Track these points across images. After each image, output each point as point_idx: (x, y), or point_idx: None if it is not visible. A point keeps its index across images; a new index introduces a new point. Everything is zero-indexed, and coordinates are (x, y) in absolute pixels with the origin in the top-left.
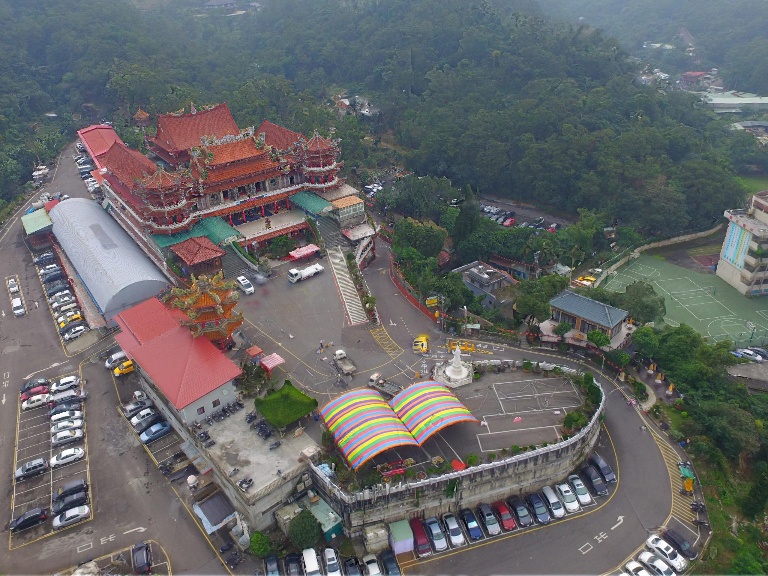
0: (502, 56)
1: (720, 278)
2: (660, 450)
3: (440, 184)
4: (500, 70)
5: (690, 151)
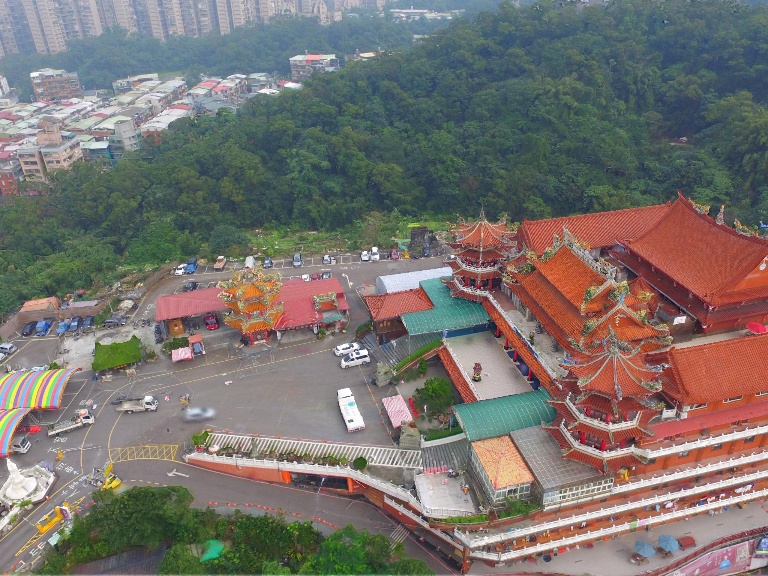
0: None
1: None
2: None
3: None
4: None
5: None
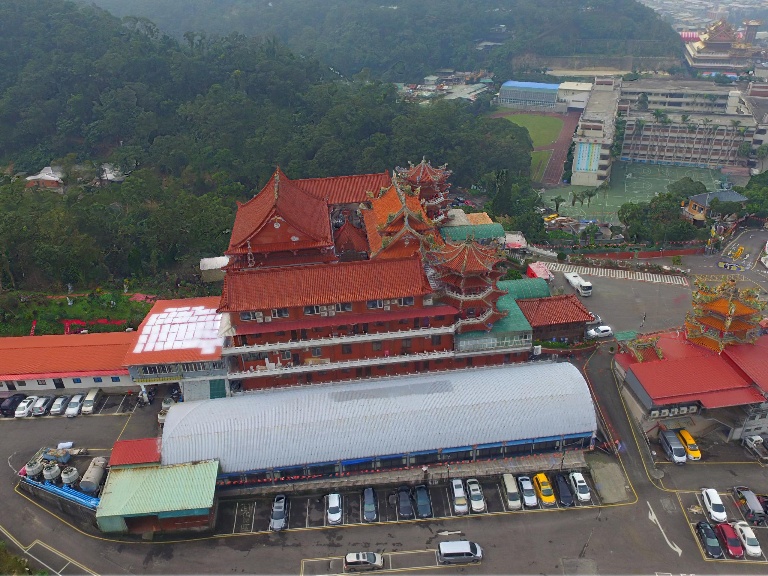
0: (240, 75)
1: (578, 185)
2: None
3: None
4: None
5: None
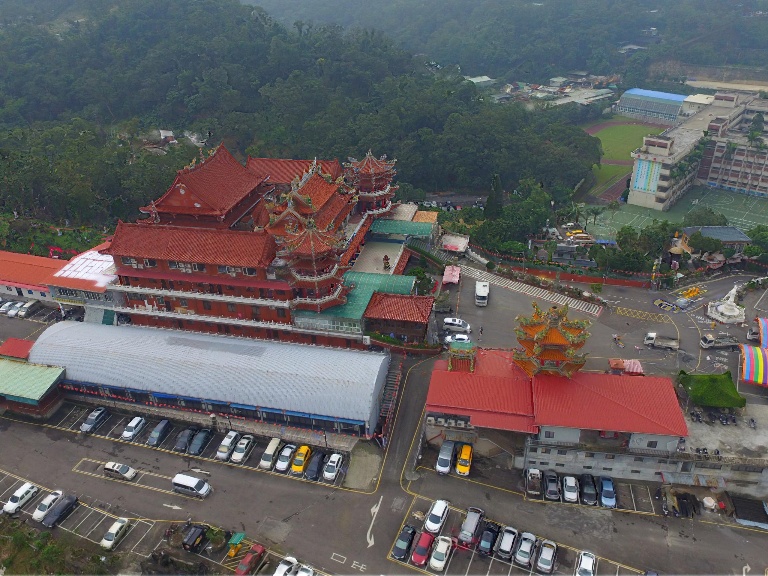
0: (325, 63)
1: (634, 205)
2: None
3: (406, 189)
4: (326, 77)
5: (528, 120)
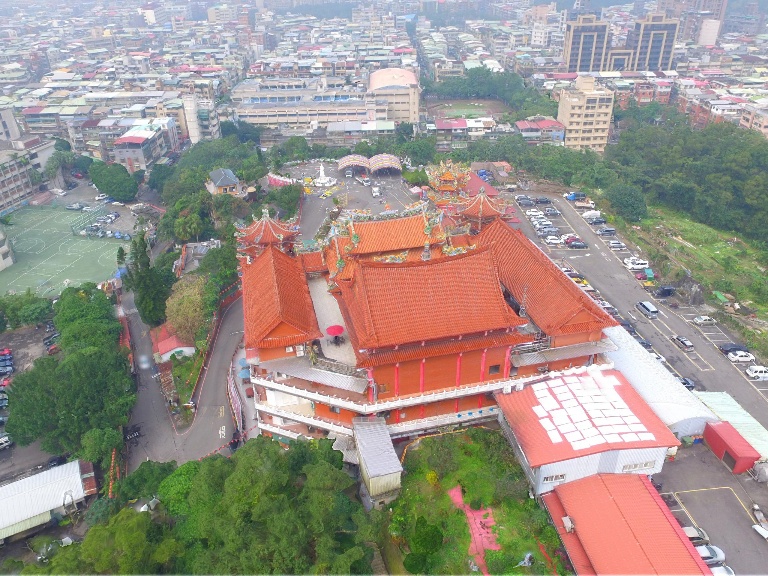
0: None
1: None
2: (264, 178)
3: None
4: None
5: None
